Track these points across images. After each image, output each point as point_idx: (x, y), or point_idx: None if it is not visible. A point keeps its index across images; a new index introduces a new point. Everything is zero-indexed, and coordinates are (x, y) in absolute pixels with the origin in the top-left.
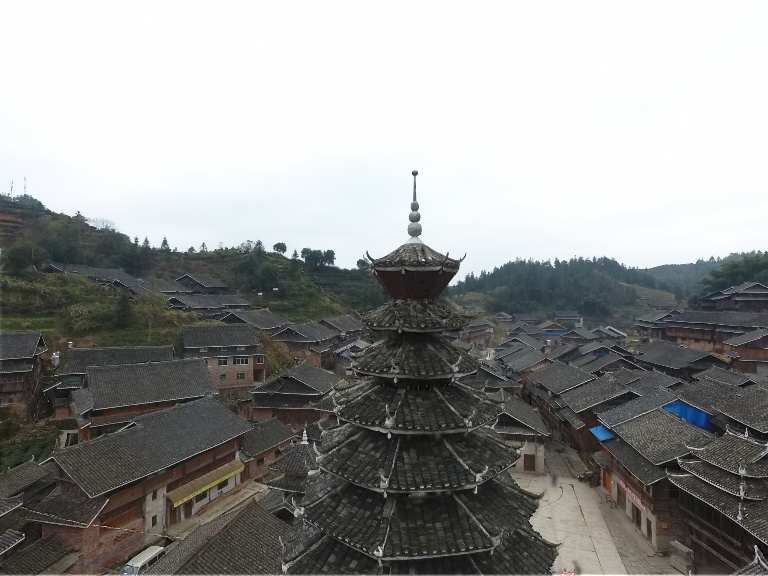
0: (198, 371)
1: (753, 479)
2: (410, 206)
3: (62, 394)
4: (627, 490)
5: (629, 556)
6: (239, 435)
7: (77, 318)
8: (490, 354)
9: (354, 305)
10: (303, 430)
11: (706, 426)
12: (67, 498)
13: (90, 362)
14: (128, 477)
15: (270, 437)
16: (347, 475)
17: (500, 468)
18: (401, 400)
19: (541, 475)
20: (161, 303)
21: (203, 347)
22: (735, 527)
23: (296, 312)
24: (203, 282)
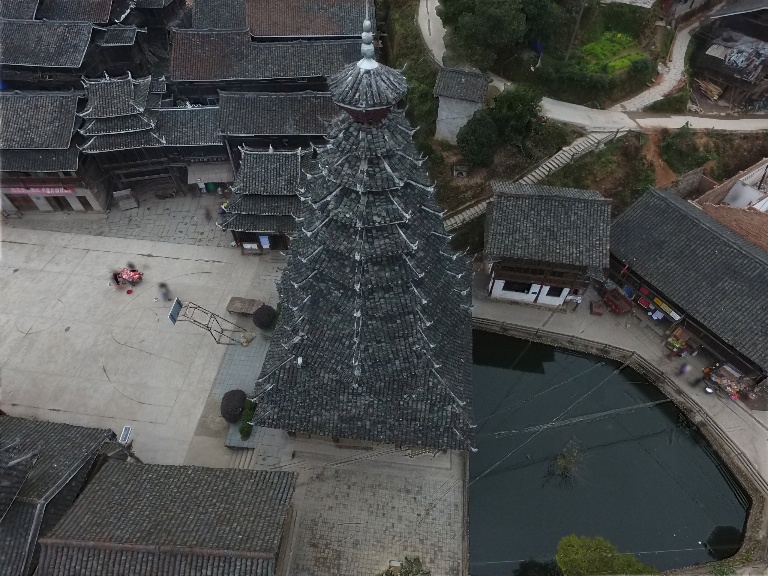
0: None
1: None
2: (368, 27)
3: None
4: (31, 191)
5: (102, 231)
6: None
7: None
8: None
9: None
10: None
11: (3, 86)
12: None
13: None
14: None
15: None
16: None
17: None
18: None
19: None
20: None
21: None
22: (157, 150)
23: None
24: None
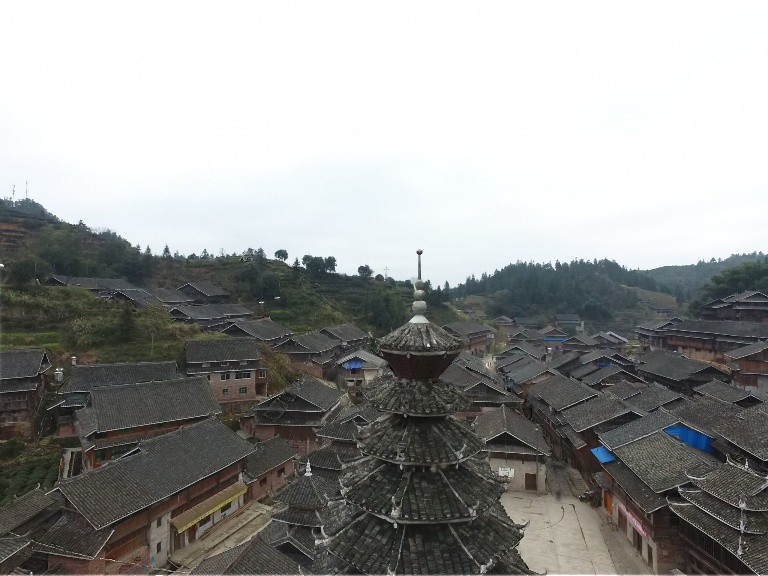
0: (201, 390)
1: (753, 512)
2: None
3: (66, 412)
4: (628, 514)
5: None
6: (242, 458)
7: (80, 332)
8: (491, 363)
9: (355, 313)
10: (306, 456)
11: (707, 449)
12: (73, 528)
13: (93, 379)
14: (133, 507)
15: (273, 456)
16: (354, 563)
17: (504, 553)
18: (407, 485)
19: (542, 494)
20: (164, 316)
21: (206, 362)
22: (735, 560)
23: (298, 321)
24: (205, 291)
